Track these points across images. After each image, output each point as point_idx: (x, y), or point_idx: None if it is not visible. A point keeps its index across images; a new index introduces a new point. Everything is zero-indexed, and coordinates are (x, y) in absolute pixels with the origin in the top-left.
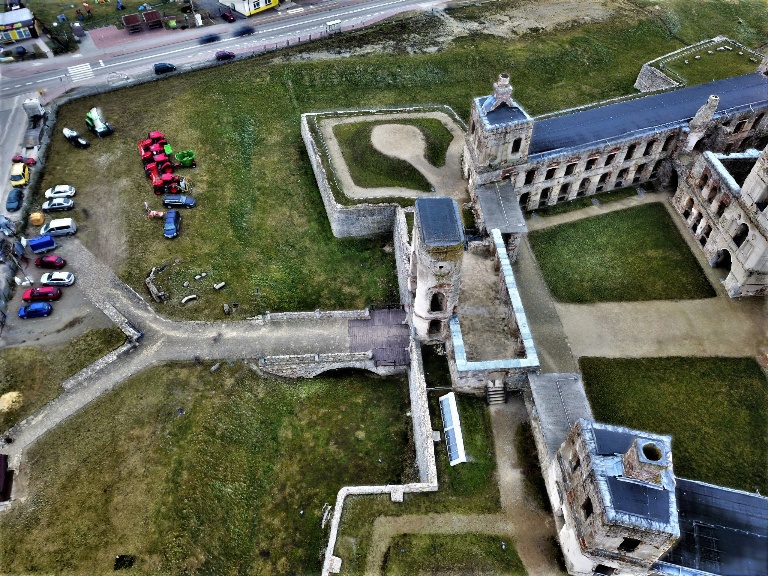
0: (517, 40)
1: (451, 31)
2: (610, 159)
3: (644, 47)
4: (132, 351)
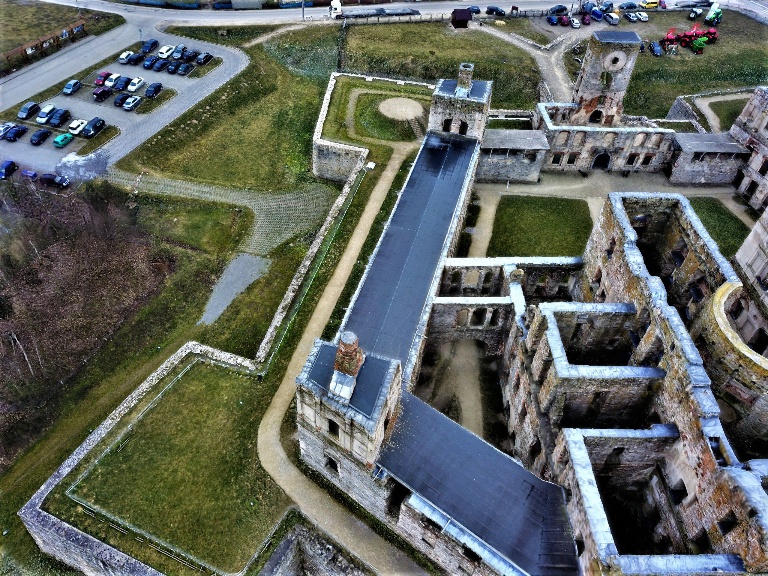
0: None
1: None
2: None
3: None
4: (537, 48)
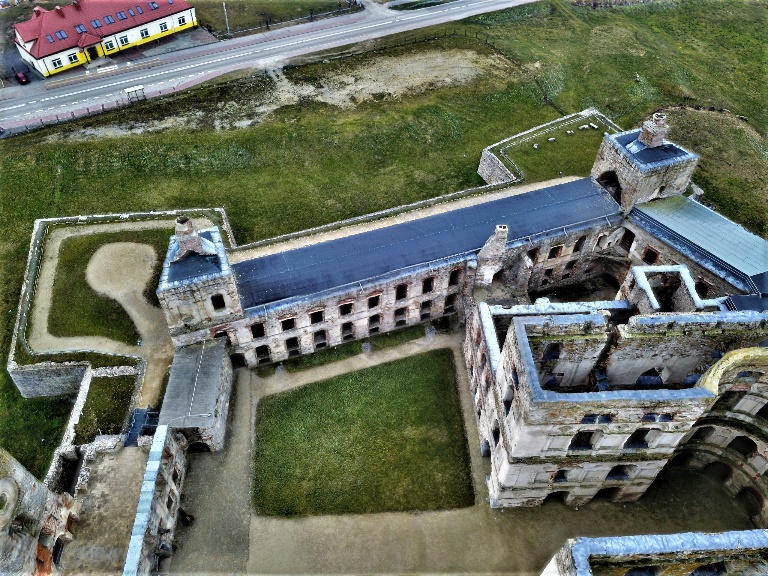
0: (352, 110)
1: (278, 98)
2: (376, 300)
3: (507, 117)
4: None
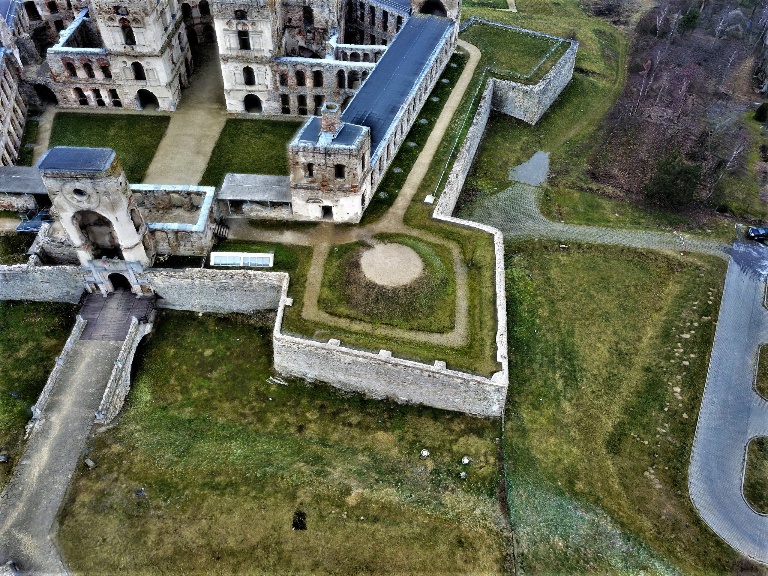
0: None
1: None
2: None
3: None
4: (18, 569)
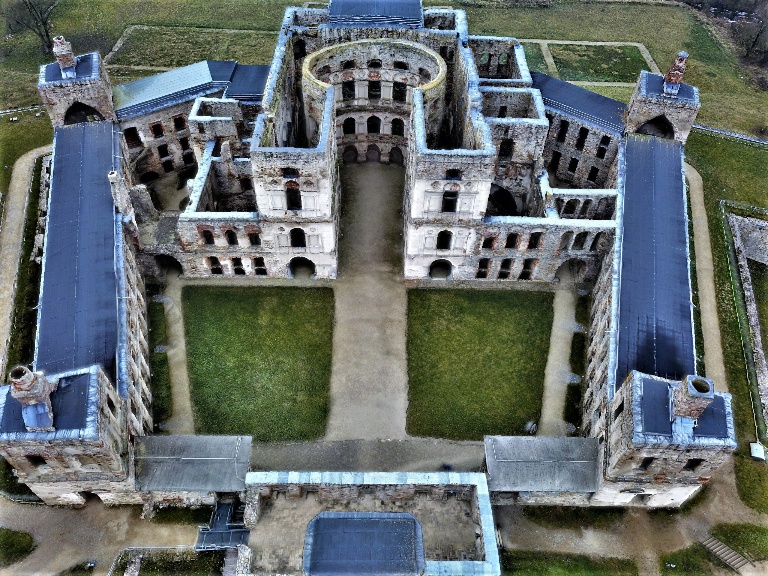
0: None
1: None
2: None
3: None
4: None
